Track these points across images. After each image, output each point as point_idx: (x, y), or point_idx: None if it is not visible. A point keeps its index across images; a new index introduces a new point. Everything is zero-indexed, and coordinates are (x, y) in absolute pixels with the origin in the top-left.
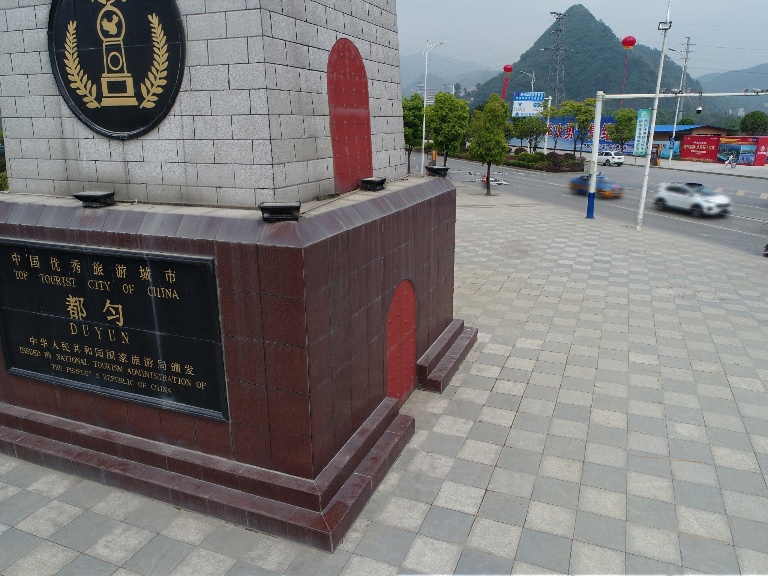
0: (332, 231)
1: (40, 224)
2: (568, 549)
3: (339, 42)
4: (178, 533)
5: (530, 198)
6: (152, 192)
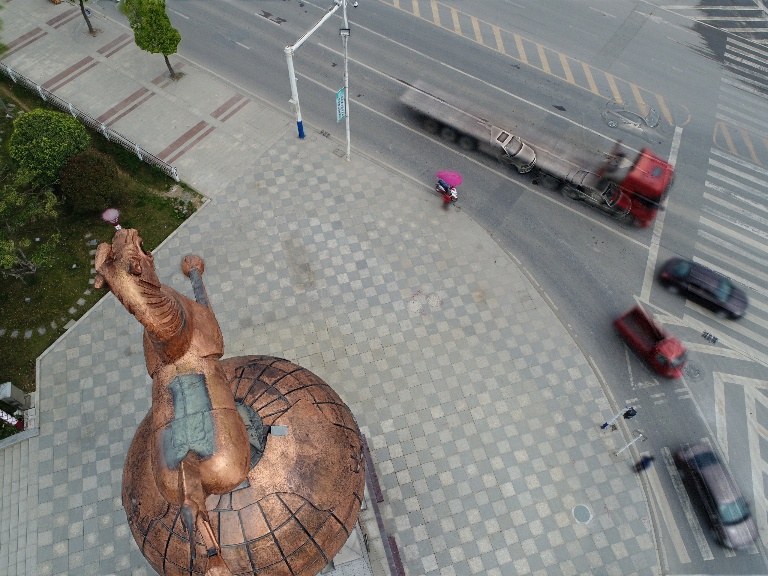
0: (397, 575)
1: None
2: (467, 565)
3: None
4: None
5: (214, 67)
6: None
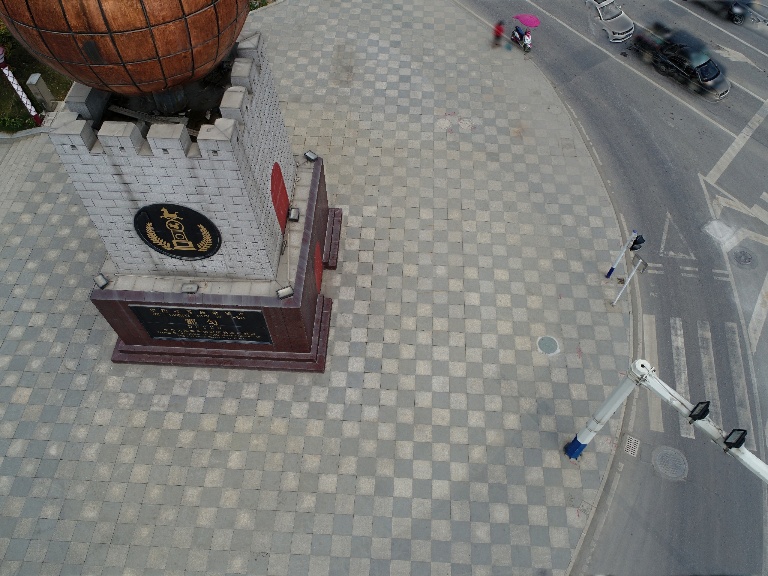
0: (302, 285)
1: (166, 302)
2: (398, 349)
3: (271, 177)
4: (267, 381)
5: None
6: (210, 275)
